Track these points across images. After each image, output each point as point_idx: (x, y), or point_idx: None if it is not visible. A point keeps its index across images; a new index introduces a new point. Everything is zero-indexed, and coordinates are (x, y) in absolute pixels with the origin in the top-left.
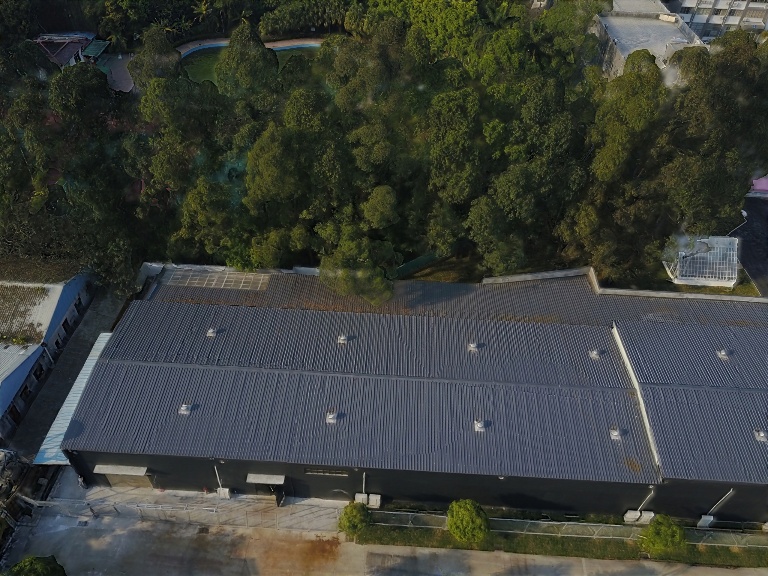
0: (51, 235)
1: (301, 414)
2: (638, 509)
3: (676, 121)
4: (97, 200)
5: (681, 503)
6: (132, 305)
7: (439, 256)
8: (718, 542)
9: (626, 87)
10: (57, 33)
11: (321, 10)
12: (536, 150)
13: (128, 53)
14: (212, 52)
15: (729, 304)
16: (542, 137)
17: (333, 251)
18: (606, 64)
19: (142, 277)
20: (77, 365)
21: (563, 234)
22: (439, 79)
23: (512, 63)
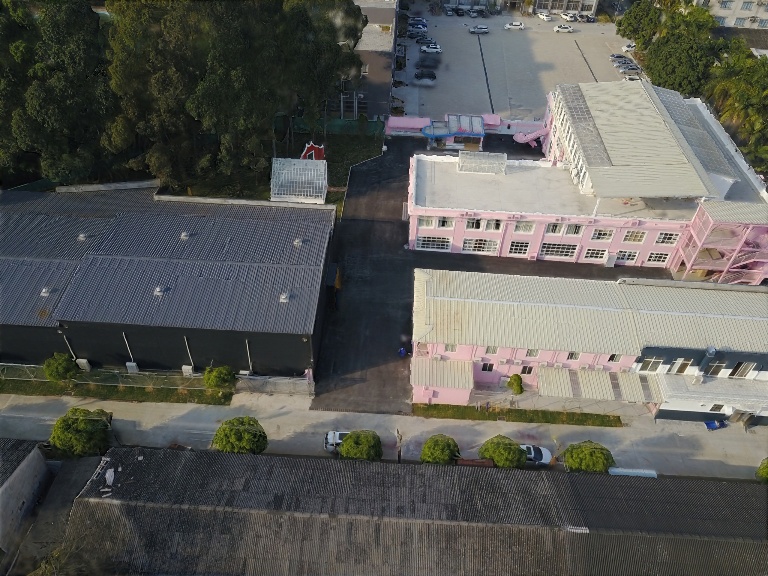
0: None
1: None
2: (74, 357)
3: (163, 40)
4: None
5: (103, 350)
6: None
7: (3, 165)
8: (137, 384)
9: (117, 10)
10: None
11: None
12: (59, 67)
13: None
14: None
15: (266, 208)
16: (61, 56)
17: None
18: None
19: None
20: None
21: (105, 144)
22: None
23: None
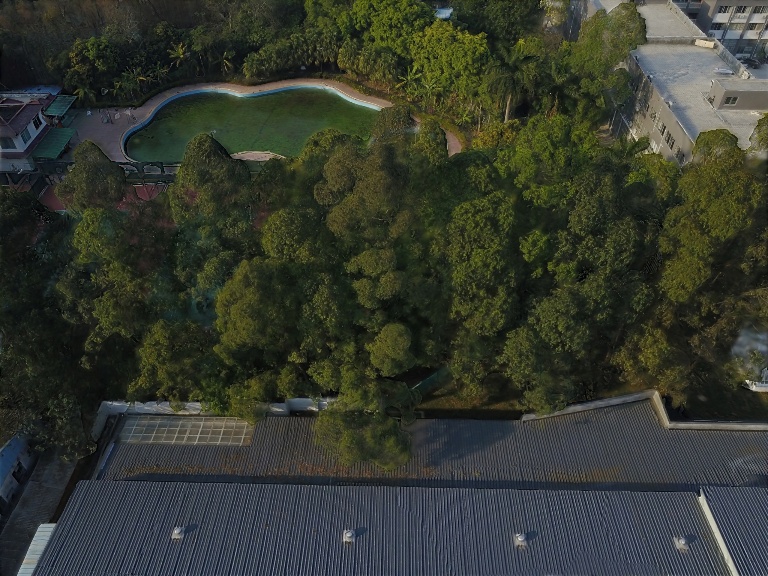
0: None
1: None
2: None
3: None
4: (31, 350)
5: None
6: (77, 490)
7: (467, 395)
8: None
9: (707, 187)
10: (18, 89)
11: (311, 48)
12: (589, 267)
13: (98, 107)
14: (192, 100)
15: None
16: (597, 251)
17: (333, 401)
18: (640, 103)
19: (101, 420)
20: (10, 570)
21: (624, 364)
22: (460, 181)
23: (555, 161)
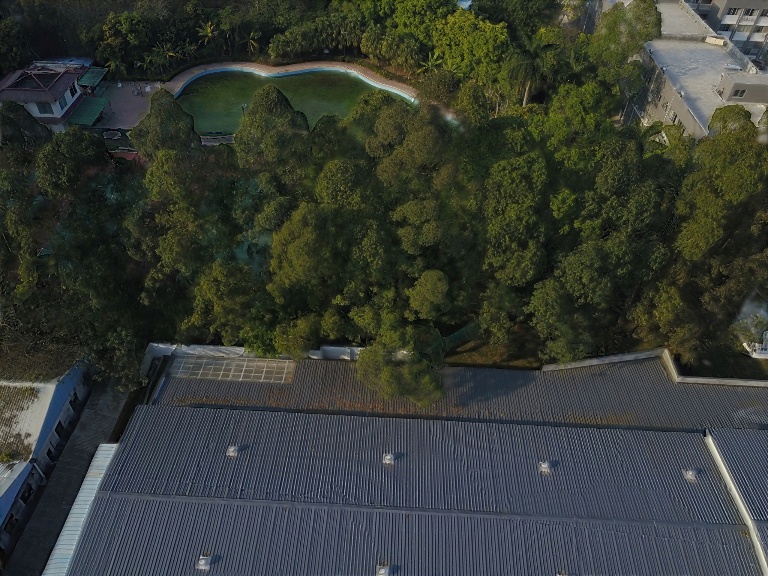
0: (41, 328)
1: (345, 567)
2: None
3: None
4: (95, 285)
5: None
6: (137, 412)
7: (494, 343)
8: None
9: (723, 154)
10: (51, 59)
11: (335, 31)
12: (612, 225)
13: (128, 80)
14: (218, 78)
15: None
16: (620, 210)
17: (372, 342)
18: (652, 94)
19: (147, 361)
20: (72, 484)
21: (639, 318)
22: (497, 142)
23: (587, 125)
